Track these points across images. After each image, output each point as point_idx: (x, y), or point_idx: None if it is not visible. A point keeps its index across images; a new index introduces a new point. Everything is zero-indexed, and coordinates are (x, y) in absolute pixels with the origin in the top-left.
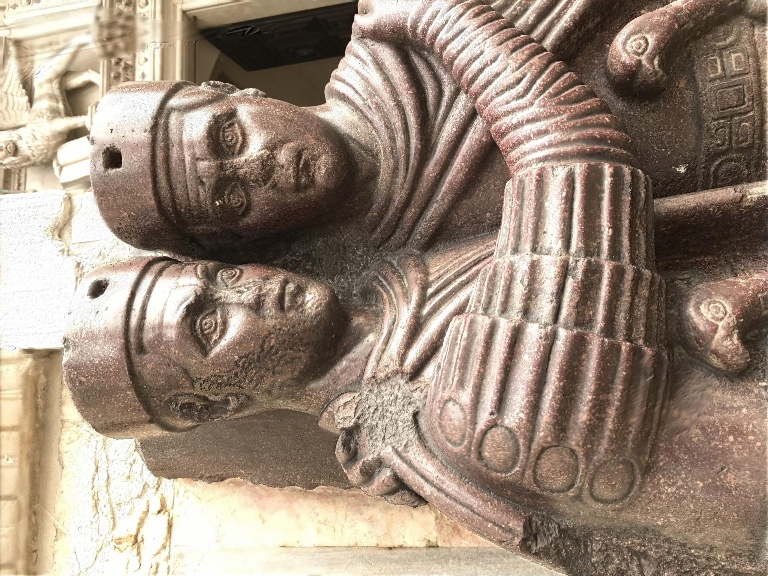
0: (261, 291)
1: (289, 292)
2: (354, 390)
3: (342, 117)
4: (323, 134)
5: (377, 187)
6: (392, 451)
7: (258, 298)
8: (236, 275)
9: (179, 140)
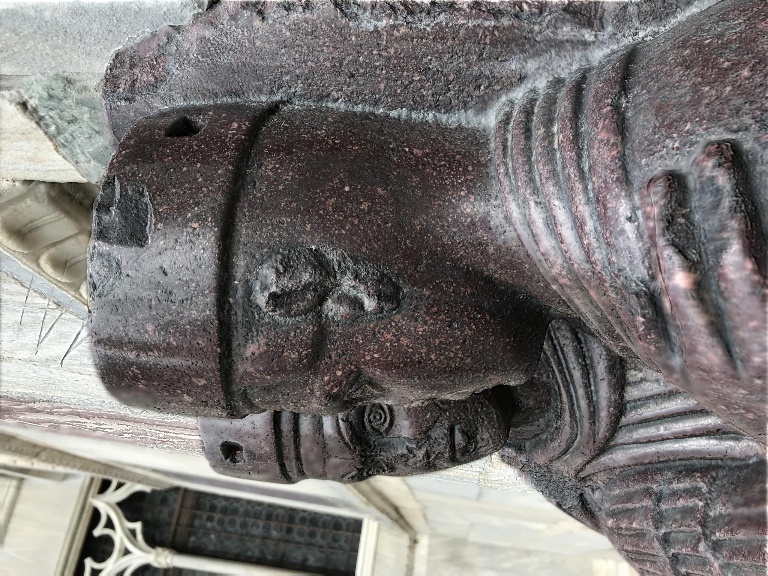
0: (430, 458)
1: (460, 448)
2: (519, 444)
3: (543, 288)
4: (514, 360)
5: (579, 319)
6: (556, 505)
7: (428, 463)
8: (387, 419)
9: (279, 409)
